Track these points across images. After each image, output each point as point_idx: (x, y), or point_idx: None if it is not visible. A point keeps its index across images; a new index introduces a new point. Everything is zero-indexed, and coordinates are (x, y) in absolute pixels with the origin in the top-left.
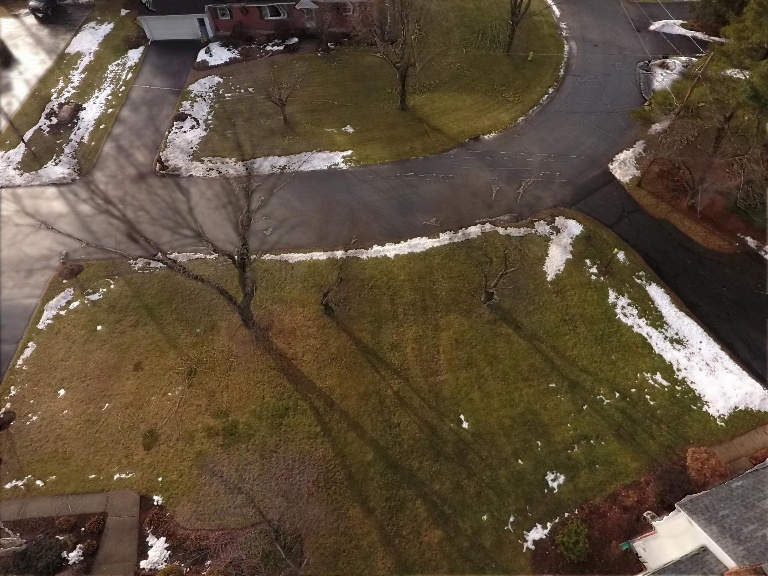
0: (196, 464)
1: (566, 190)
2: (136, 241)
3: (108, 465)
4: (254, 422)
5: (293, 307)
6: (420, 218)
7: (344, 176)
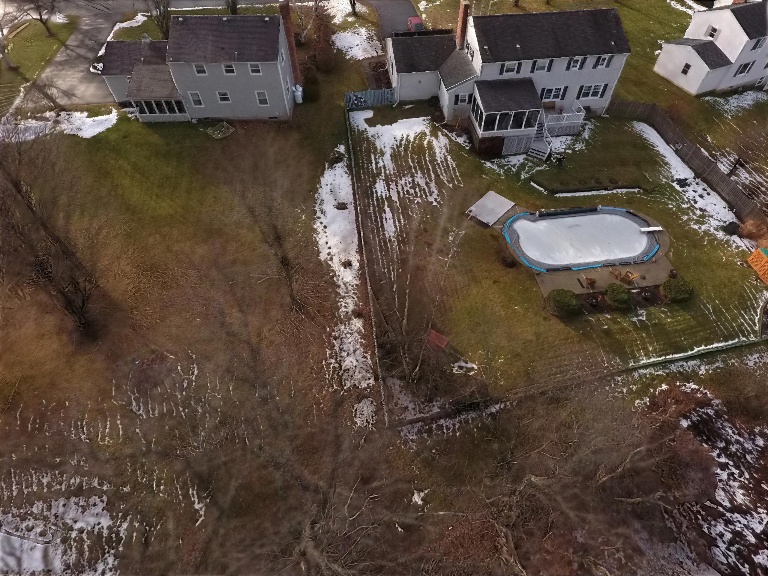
0: None
1: None
2: None
3: None
4: None
5: (531, 3)
6: None
7: None
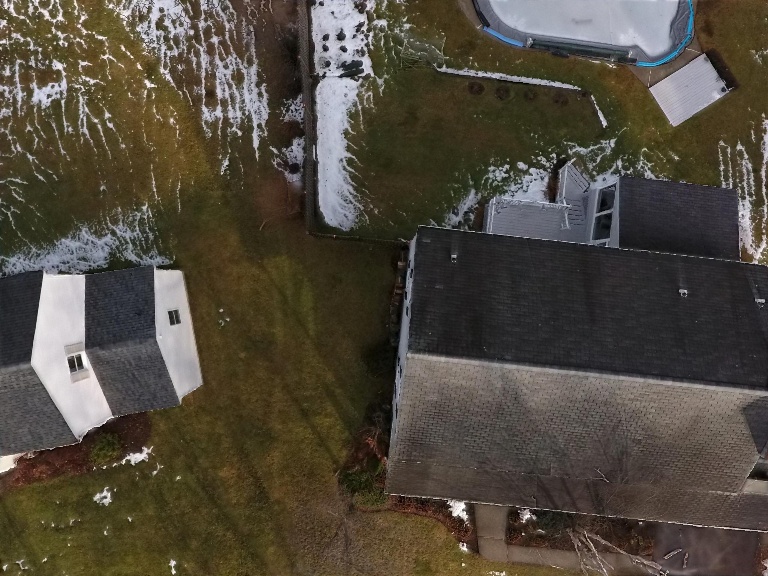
0: (432, 573)
1: None
2: None
3: None
4: None
5: None
6: None
7: None
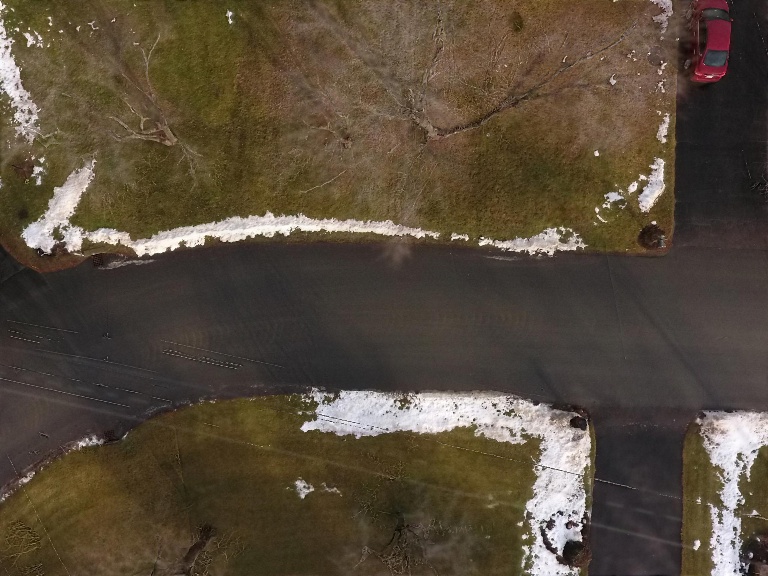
0: None
1: (18, 303)
2: (585, 280)
3: (548, 3)
4: (422, 29)
5: None
6: (224, 274)
7: (317, 373)
